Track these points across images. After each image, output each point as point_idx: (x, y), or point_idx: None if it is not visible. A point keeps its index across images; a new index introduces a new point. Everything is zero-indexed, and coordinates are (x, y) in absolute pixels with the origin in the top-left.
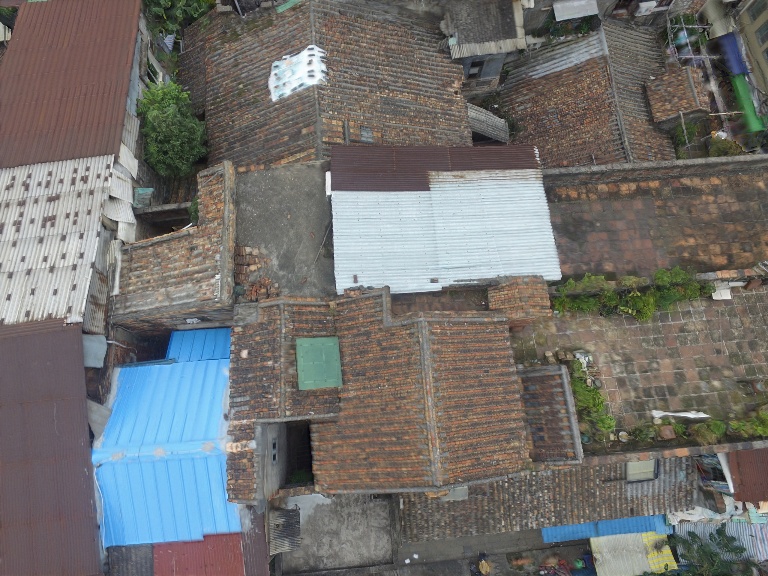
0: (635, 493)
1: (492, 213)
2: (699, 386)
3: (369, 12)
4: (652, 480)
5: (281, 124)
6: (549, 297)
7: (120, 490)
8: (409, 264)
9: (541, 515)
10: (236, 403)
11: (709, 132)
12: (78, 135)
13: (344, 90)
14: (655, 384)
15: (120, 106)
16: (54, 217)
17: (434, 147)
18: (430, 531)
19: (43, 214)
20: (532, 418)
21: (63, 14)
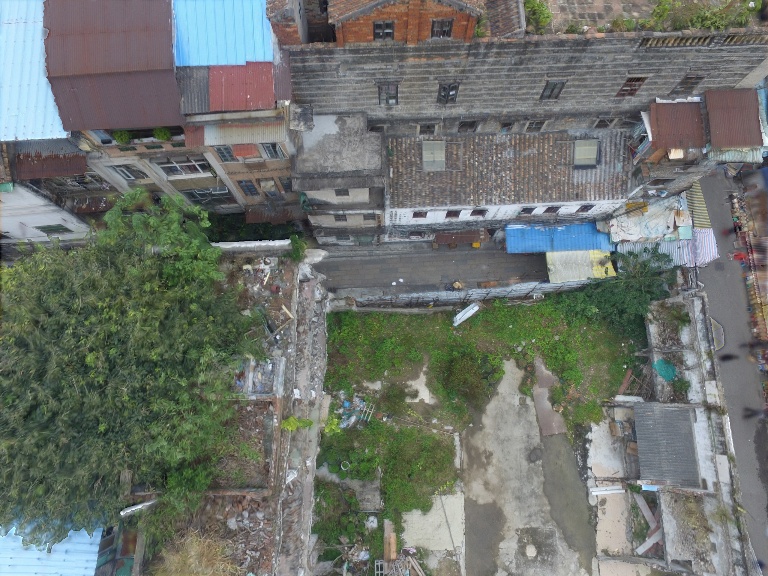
0: (580, 180)
1: None
2: (622, 15)
3: None
4: (595, 168)
5: None
6: None
7: (189, 20)
8: None
9: (503, 193)
10: None
11: None
12: None
13: None
14: (589, 11)
15: None
16: None
17: None
18: (413, 199)
19: None
20: (492, 16)
21: None
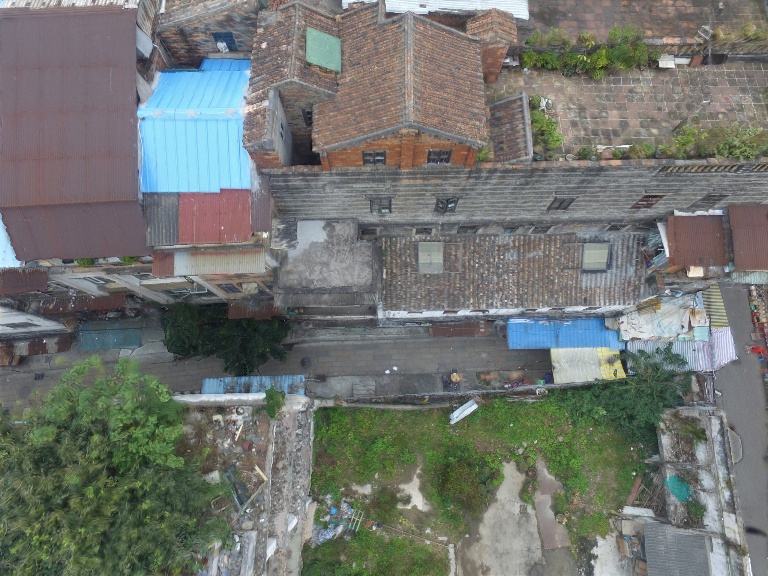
0: (589, 284)
1: None
2: (639, 132)
3: None
4: (605, 272)
5: None
6: None
7: (157, 143)
8: None
9: (505, 296)
10: (255, 80)
11: None
12: None
13: None
14: (602, 127)
15: None
16: None
17: None
18: (407, 302)
19: None
20: (495, 135)
21: None
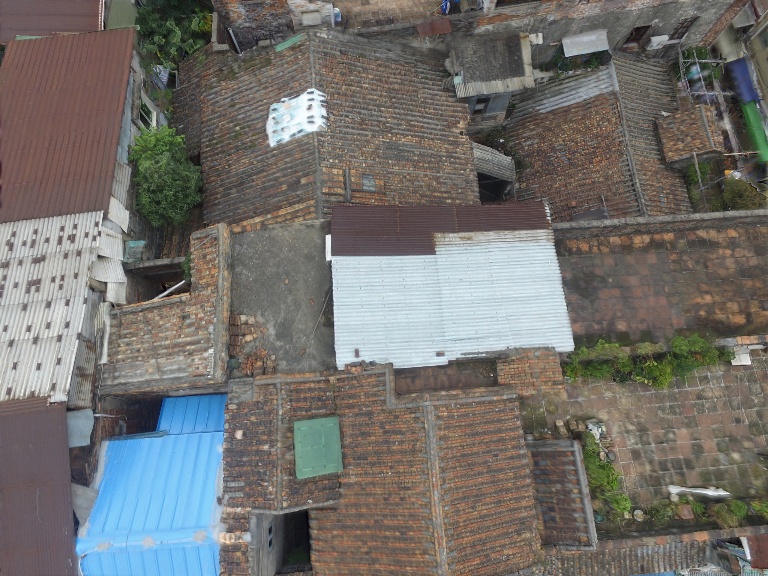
0: (645, 549)
1: (501, 278)
2: (717, 458)
3: (371, 51)
4: None
5: (279, 171)
6: (560, 364)
7: None
8: (414, 336)
9: (548, 572)
10: (230, 488)
11: (722, 170)
12: (66, 188)
13: (345, 136)
14: (671, 456)
15: (110, 156)
16: (39, 281)
17: (440, 207)
18: None
19: (27, 277)
20: (543, 496)
21: (52, 54)
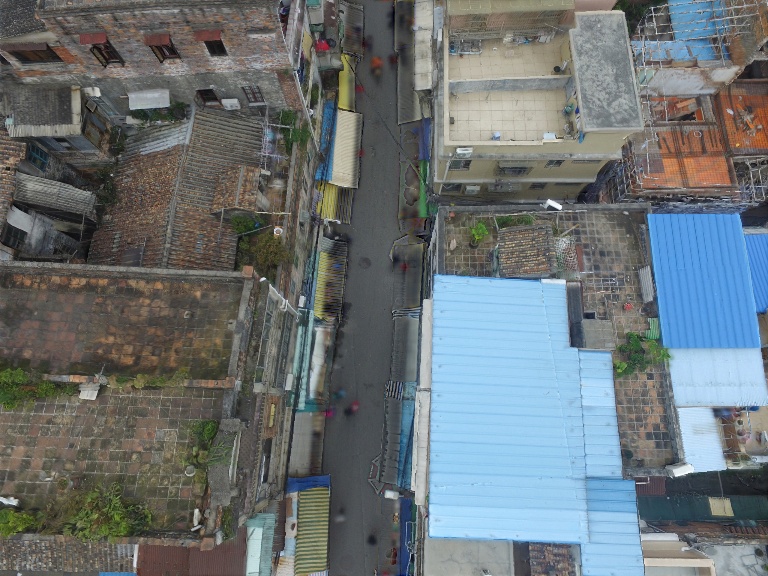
0: (125, 551)
1: None
2: (38, 475)
3: None
4: None
5: None
6: None
7: None
8: None
9: (39, 559)
10: None
11: None
12: None
13: None
14: None
15: None
16: None
17: None
18: None
19: None
20: None
21: None
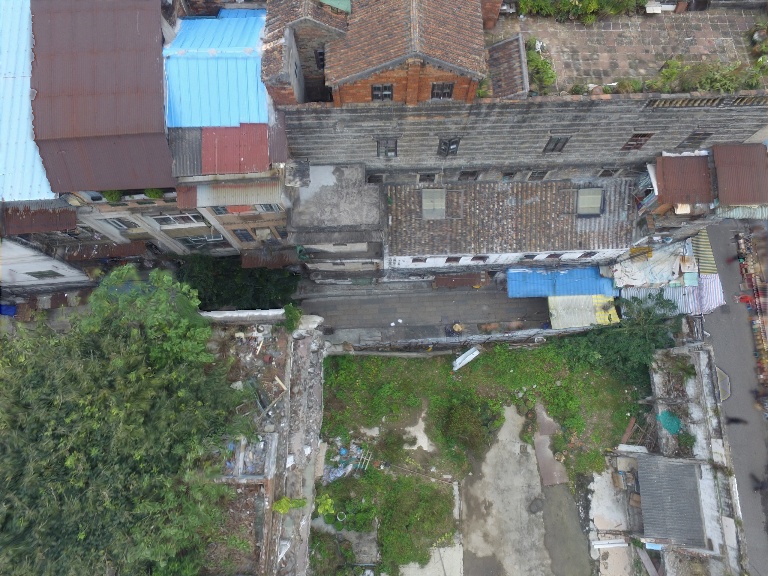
0: (584, 228)
1: None
2: (628, 72)
3: None
4: (599, 217)
5: None
6: None
7: (181, 80)
8: None
9: (505, 241)
10: (271, 21)
11: None
12: None
13: None
14: (594, 68)
15: None
16: None
17: None
18: (412, 247)
19: None
20: (494, 74)
21: None
